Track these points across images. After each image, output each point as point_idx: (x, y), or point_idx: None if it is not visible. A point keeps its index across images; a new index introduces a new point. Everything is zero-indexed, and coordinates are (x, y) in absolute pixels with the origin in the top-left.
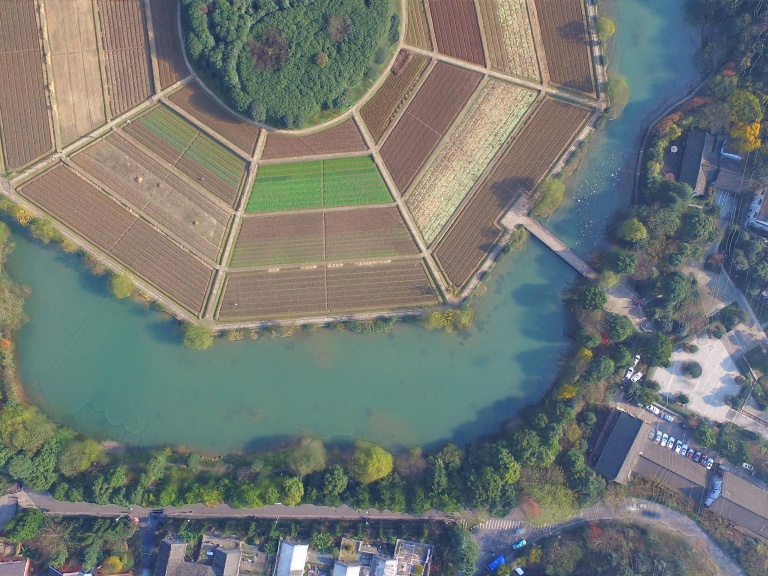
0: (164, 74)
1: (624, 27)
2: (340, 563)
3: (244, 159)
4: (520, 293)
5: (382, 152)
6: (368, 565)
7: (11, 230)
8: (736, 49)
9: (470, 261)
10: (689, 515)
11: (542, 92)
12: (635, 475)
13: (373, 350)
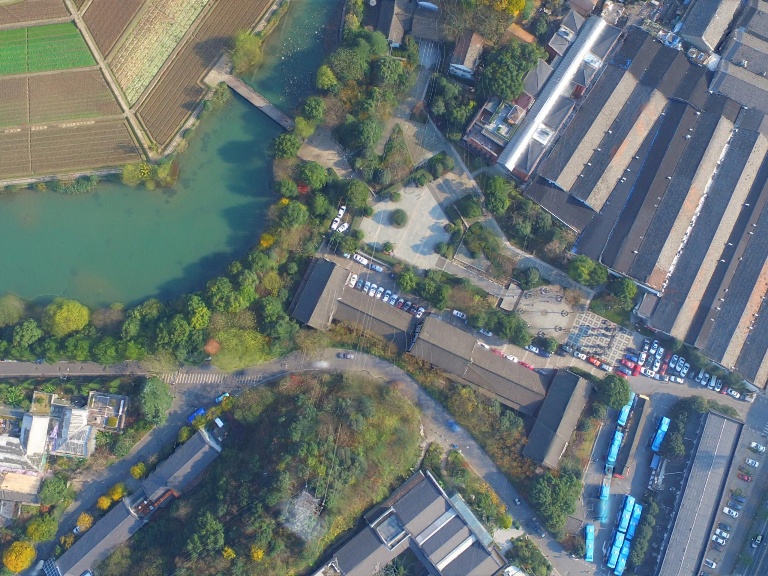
0: None
1: None
2: (27, 414)
3: None
4: (226, 150)
5: (85, 18)
6: (58, 416)
7: None
8: None
9: (173, 120)
10: (398, 364)
11: None
12: (336, 322)
13: (77, 210)
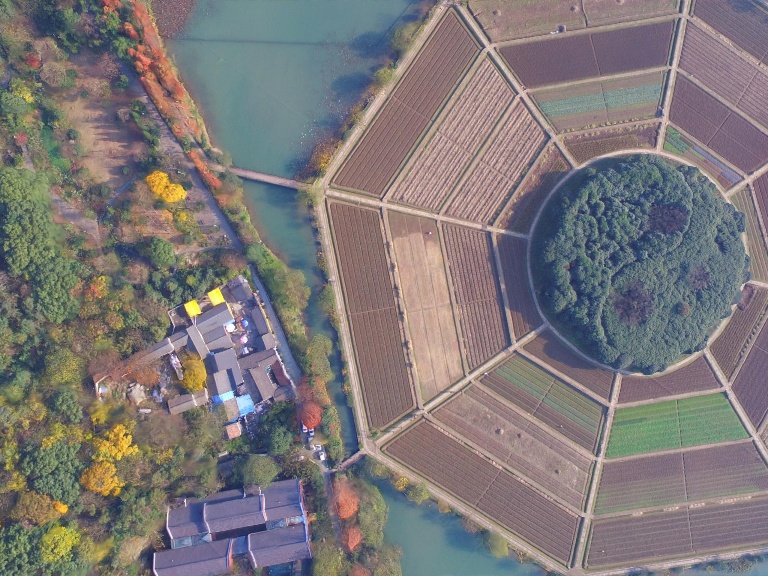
0: (518, 324)
1: None
2: None
3: (601, 404)
4: None
5: (734, 388)
6: None
7: (380, 491)
8: None
9: None
10: None
11: None
12: None
13: None
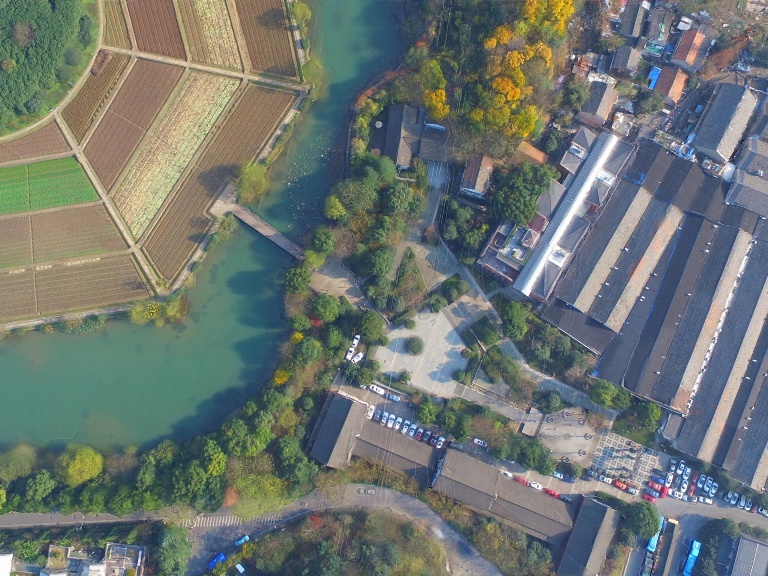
0: None
1: (326, 10)
2: (44, 571)
3: None
4: (235, 281)
5: (86, 152)
6: (75, 571)
7: None
8: (425, 20)
9: (180, 253)
10: (420, 498)
11: (244, 80)
12: (356, 459)
13: (86, 350)
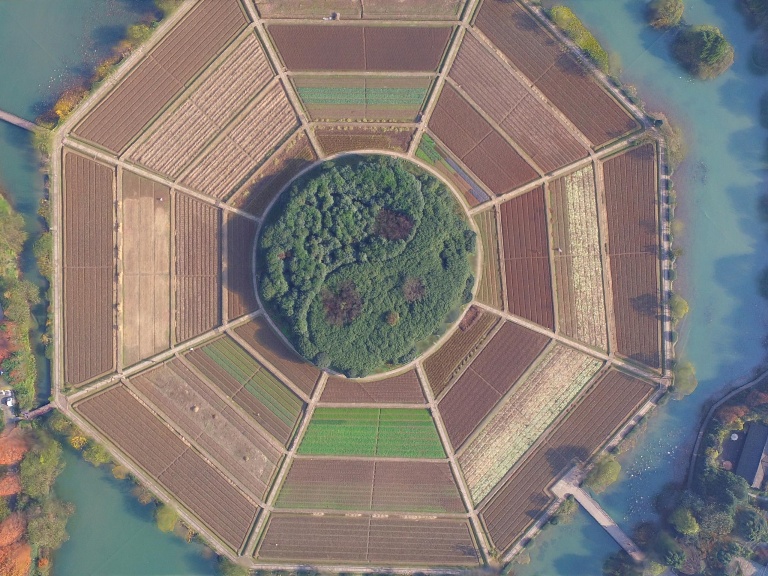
0: (233, 306)
1: (697, 303)
2: None
3: (302, 399)
4: (562, 562)
5: (440, 406)
6: None
7: (63, 447)
8: None
9: (516, 526)
10: None
11: (608, 362)
12: None
13: None
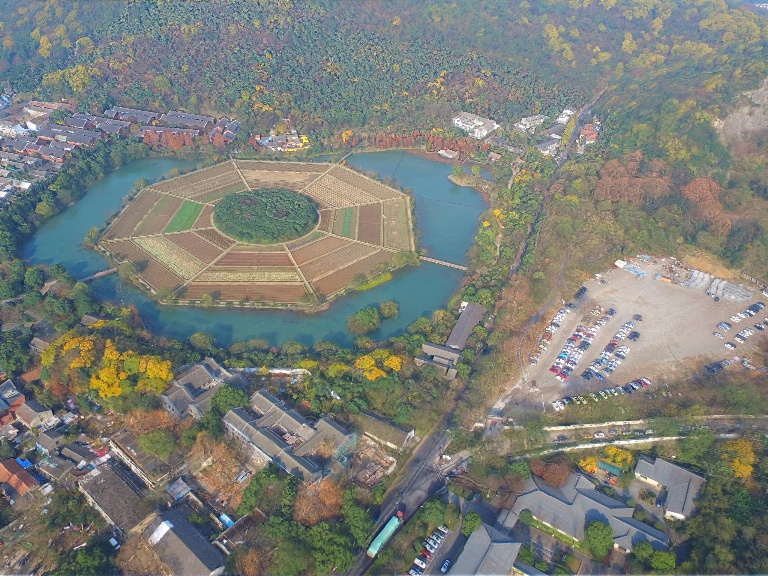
0: None
1: None
2: None
3: None
4: None
5: None
6: None
7: None
8: None
9: None
10: None
11: (188, 280)
12: None
13: None
